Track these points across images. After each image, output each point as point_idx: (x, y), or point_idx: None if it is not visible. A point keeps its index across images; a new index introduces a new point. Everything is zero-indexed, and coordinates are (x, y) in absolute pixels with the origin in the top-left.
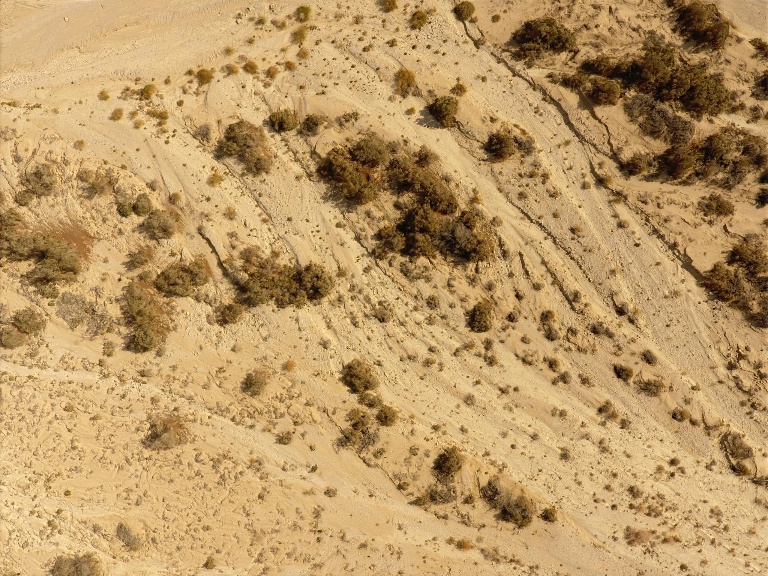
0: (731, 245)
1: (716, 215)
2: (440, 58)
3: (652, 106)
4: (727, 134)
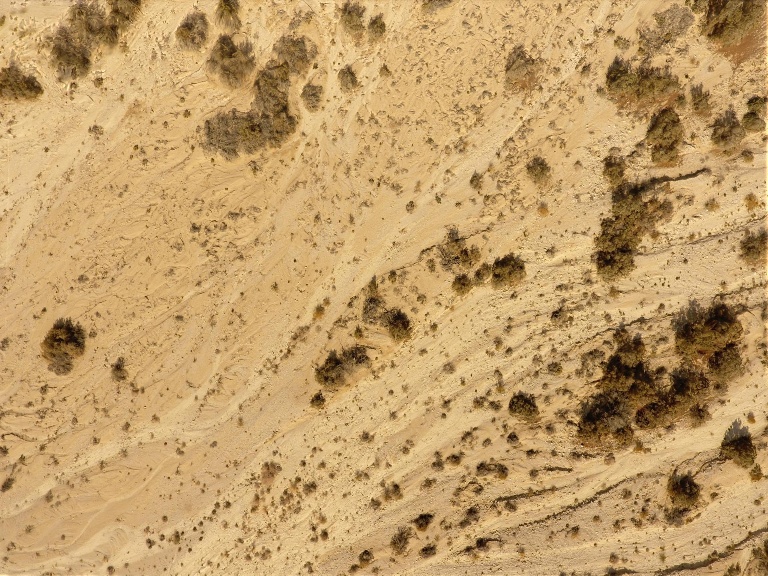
0: None
1: None
2: None
3: None
4: None
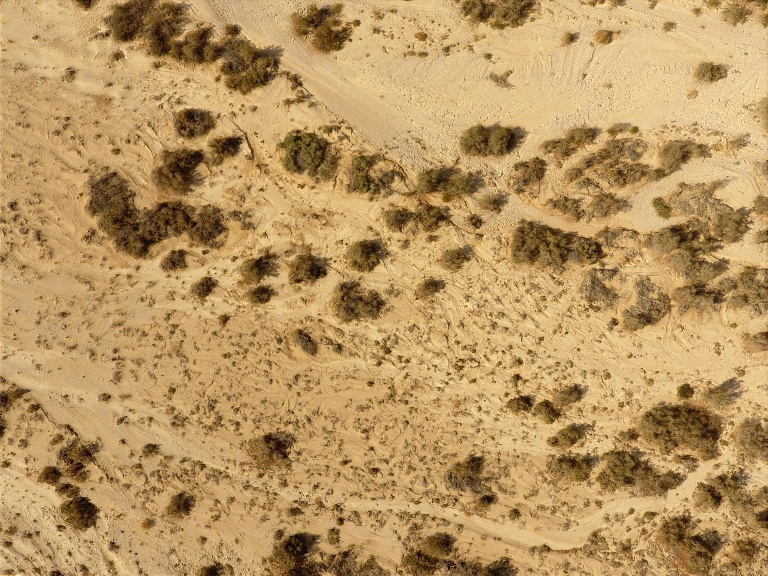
0: None
1: None
2: None
3: None
4: None
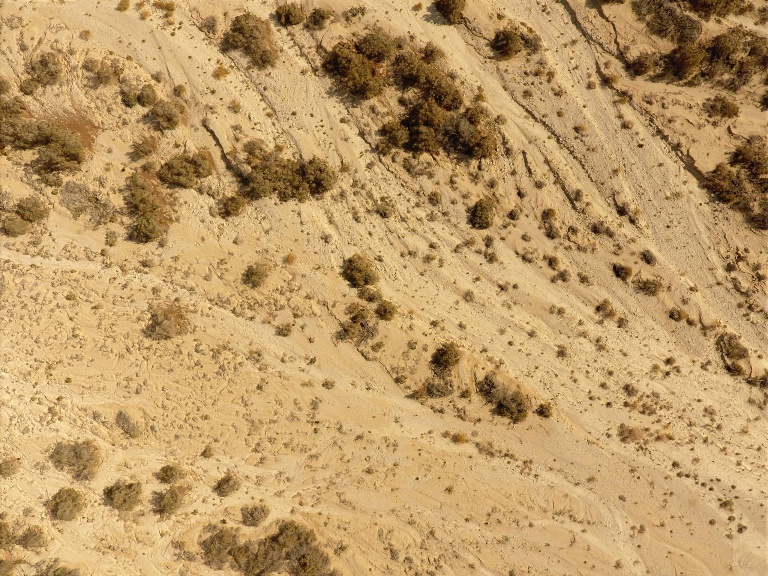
0: (734, 147)
1: (720, 116)
2: None
3: (660, 4)
4: (734, 34)
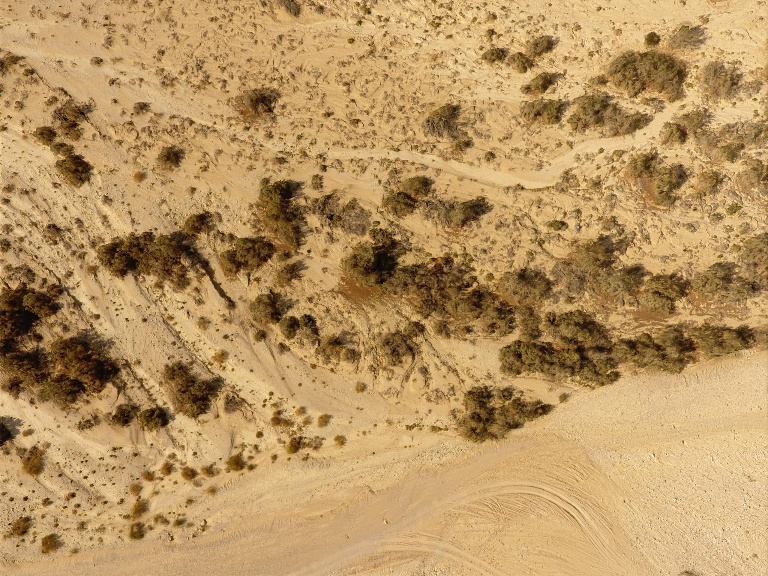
0: None
1: None
2: (1, 488)
3: None
4: None
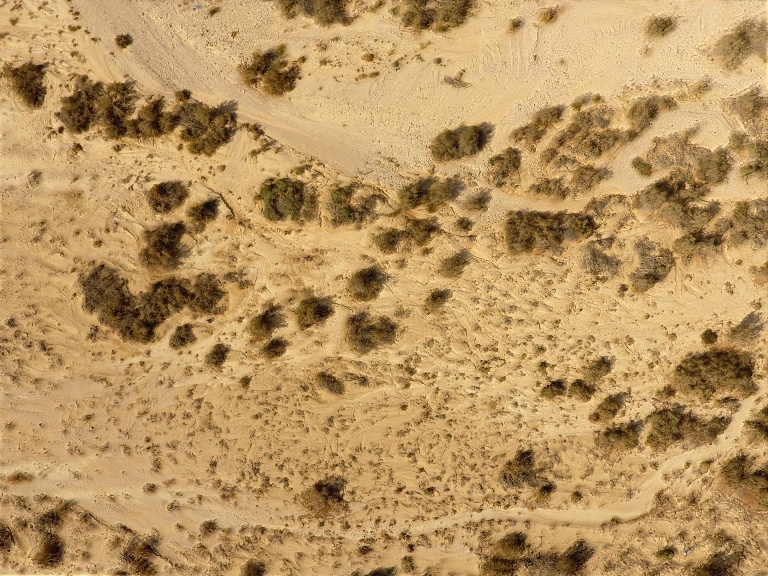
0: None
1: None
2: None
3: None
4: None
